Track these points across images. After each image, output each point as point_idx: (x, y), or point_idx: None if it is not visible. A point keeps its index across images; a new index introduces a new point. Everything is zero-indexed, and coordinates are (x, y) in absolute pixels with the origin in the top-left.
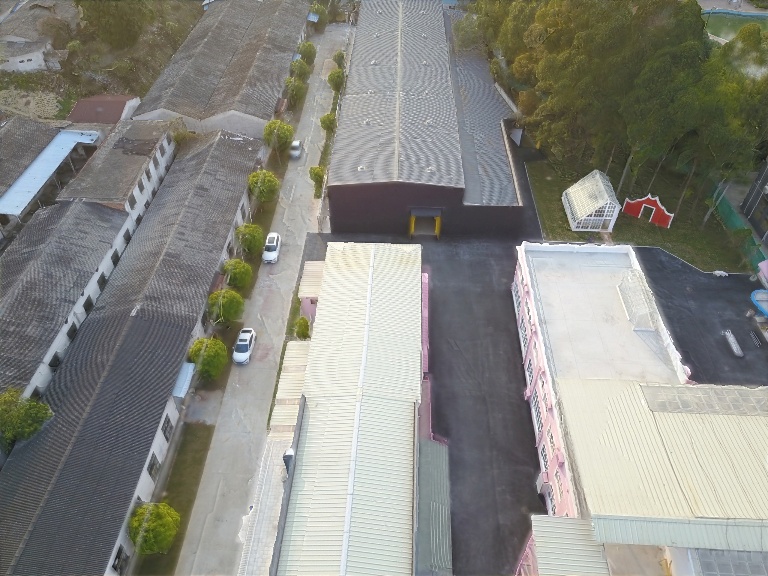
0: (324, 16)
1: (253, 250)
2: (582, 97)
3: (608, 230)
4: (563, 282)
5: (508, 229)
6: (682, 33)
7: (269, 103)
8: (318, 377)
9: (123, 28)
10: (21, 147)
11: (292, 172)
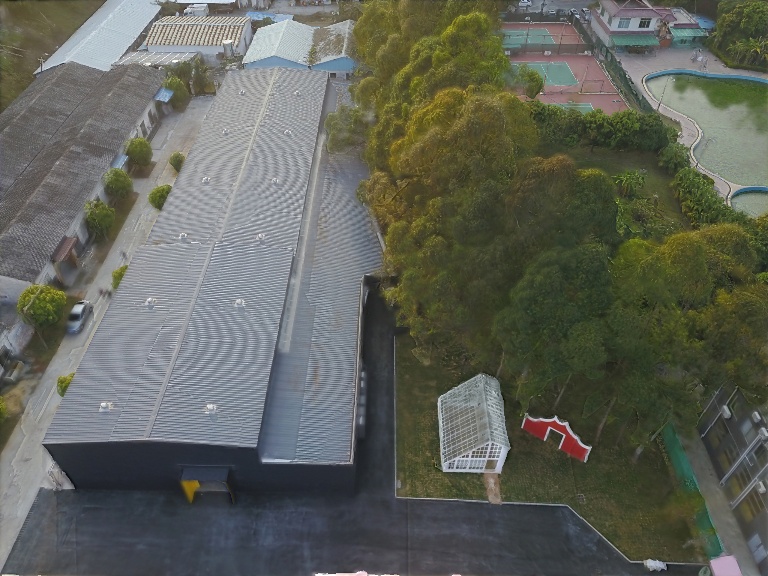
0: (181, 92)
1: None
2: (440, 299)
3: (496, 470)
4: None
5: (339, 486)
6: (580, 226)
7: (44, 249)
8: None
9: None
10: None
11: (61, 359)
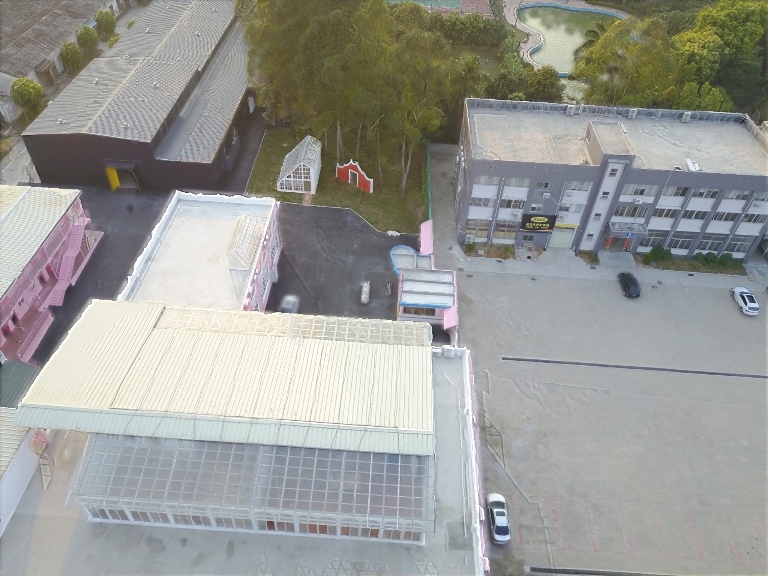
0: None
1: None
2: (267, 62)
3: (311, 192)
4: (195, 227)
5: (206, 185)
6: (334, 3)
7: (30, 63)
8: None
9: None
10: None
11: None
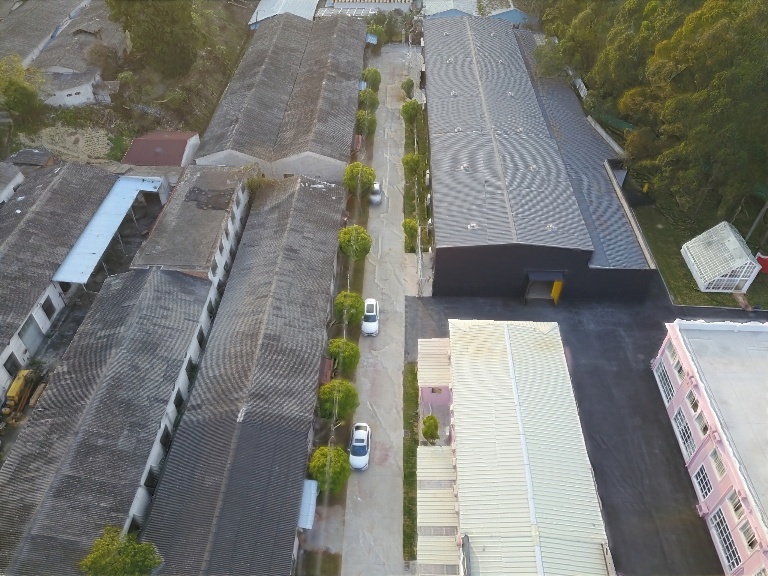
0: (382, 37)
1: (354, 323)
2: (726, 146)
3: (742, 291)
4: (733, 371)
5: (635, 293)
6: None
7: (344, 141)
8: (477, 508)
9: (177, 56)
10: (79, 198)
11: (375, 220)
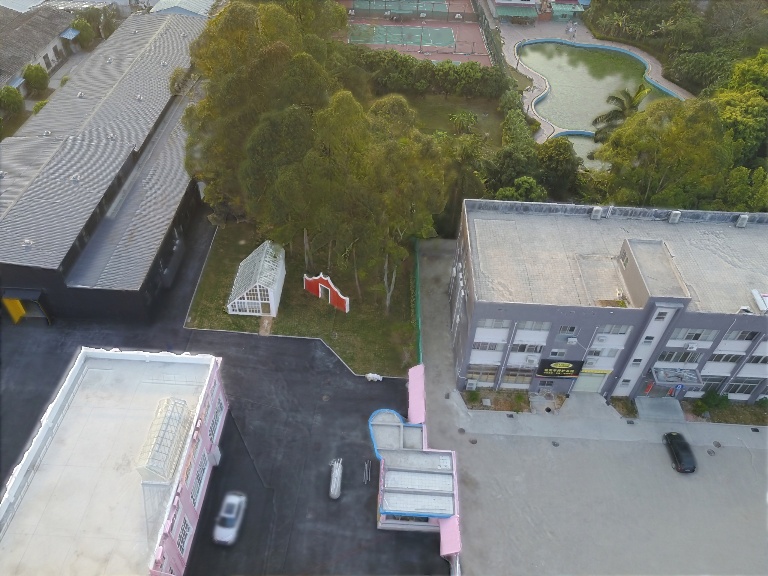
0: (87, 32)
1: None
2: (208, 162)
3: (271, 314)
4: (102, 406)
5: (135, 314)
6: (291, 94)
7: None
8: None
9: None
10: None
11: None
